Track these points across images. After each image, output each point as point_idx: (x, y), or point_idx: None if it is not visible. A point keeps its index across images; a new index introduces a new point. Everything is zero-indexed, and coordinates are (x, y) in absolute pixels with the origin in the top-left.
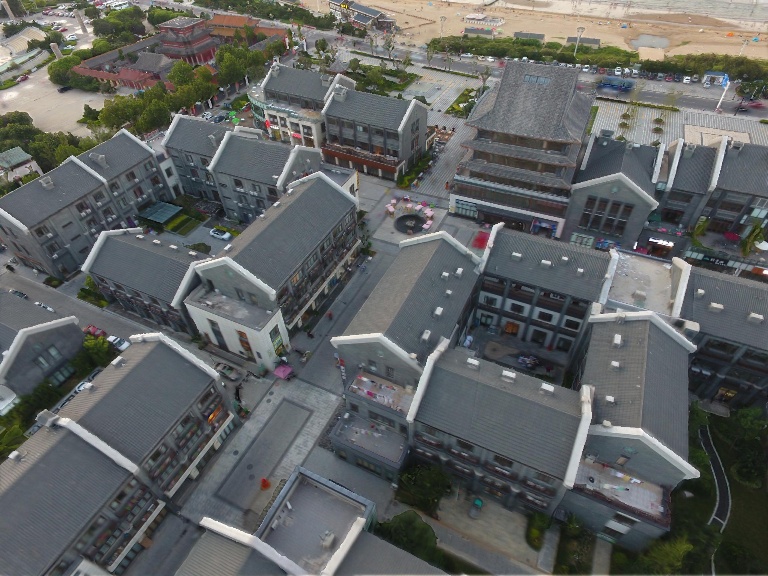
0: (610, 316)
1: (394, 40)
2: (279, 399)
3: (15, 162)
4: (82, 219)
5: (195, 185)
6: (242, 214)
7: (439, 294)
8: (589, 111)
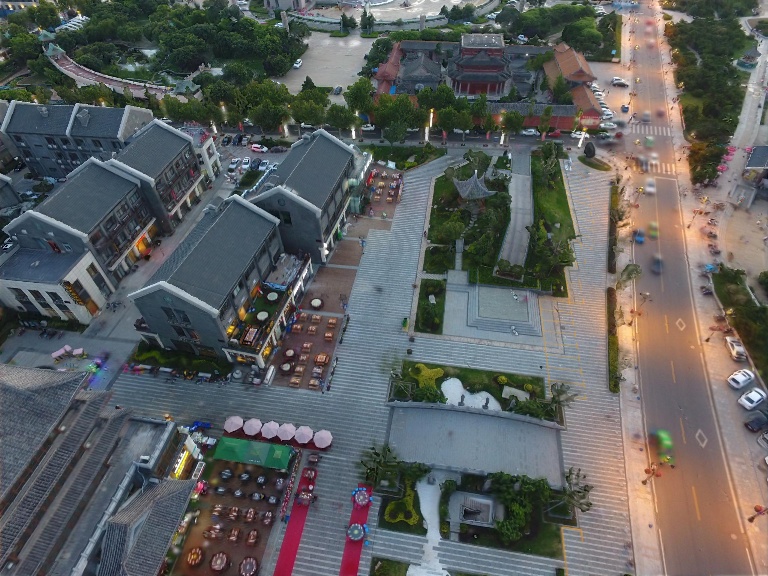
0: None
1: (714, 220)
2: None
3: (180, 90)
4: (51, 149)
5: None
6: None
7: None
8: None
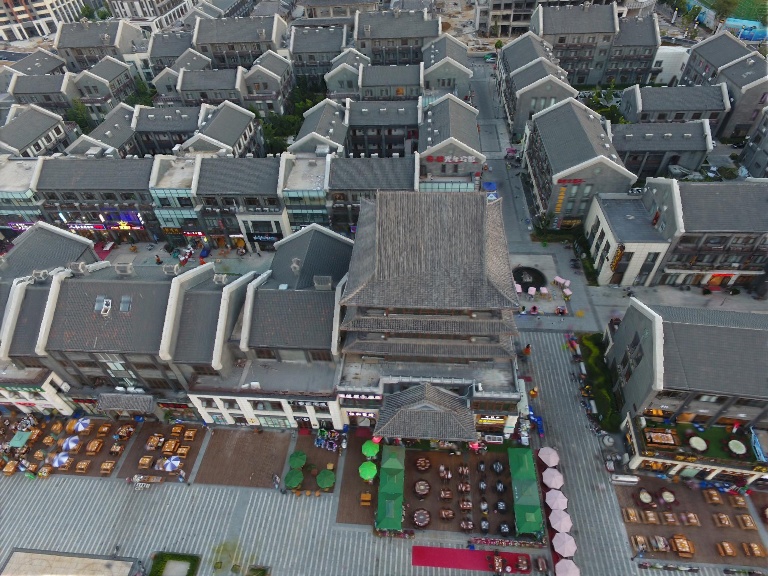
0: None
1: None
2: (503, 151)
3: None
4: None
5: None
6: None
7: None
8: (351, 264)
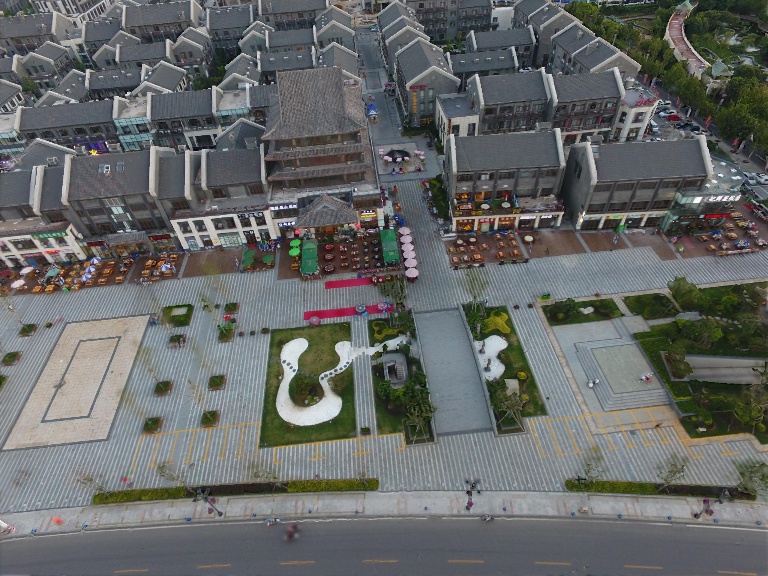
0: None
1: None
2: (383, 87)
3: None
4: None
5: None
6: None
7: None
8: (267, 123)
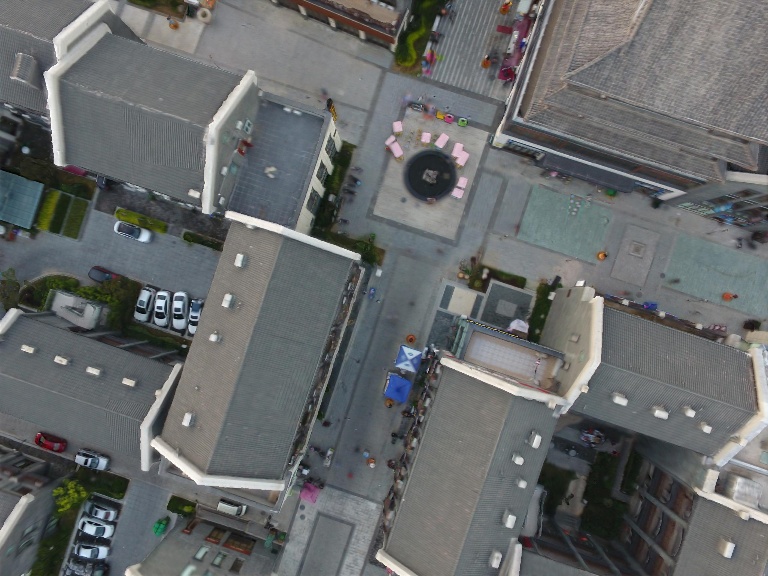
0: (728, 506)
1: None
2: (313, 514)
3: None
4: None
5: (35, 119)
6: (151, 192)
7: (509, 486)
8: None
